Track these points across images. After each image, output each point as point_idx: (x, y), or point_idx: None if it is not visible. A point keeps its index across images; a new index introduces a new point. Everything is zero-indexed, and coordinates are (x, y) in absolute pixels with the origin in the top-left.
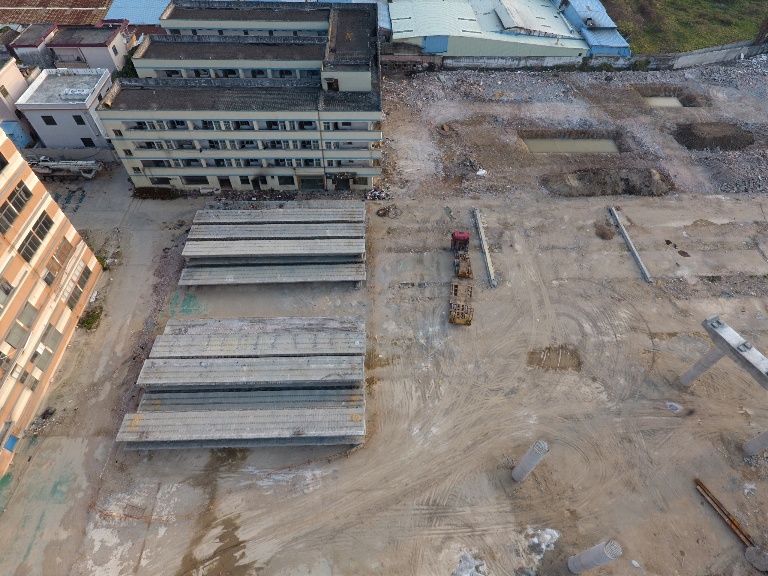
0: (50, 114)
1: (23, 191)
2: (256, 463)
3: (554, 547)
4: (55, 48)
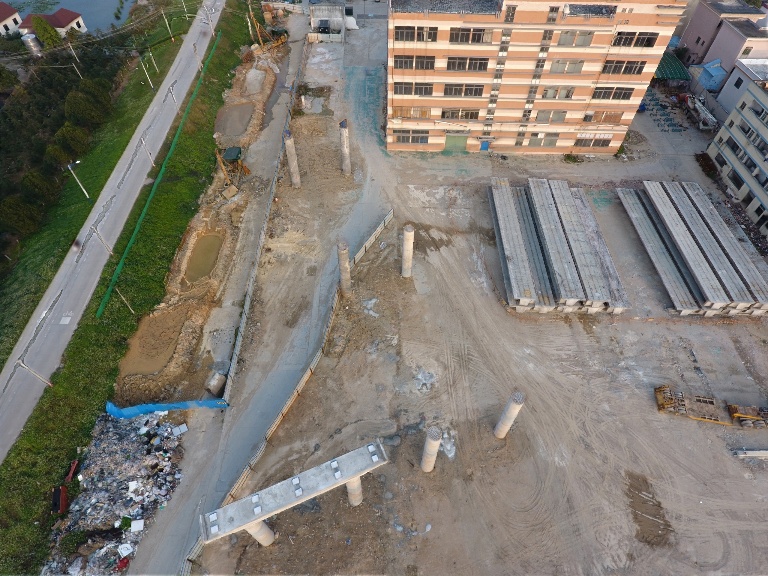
0: (744, 79)
1: (640, 68)
2: (487, 251)
3: (441, 450)
4: None
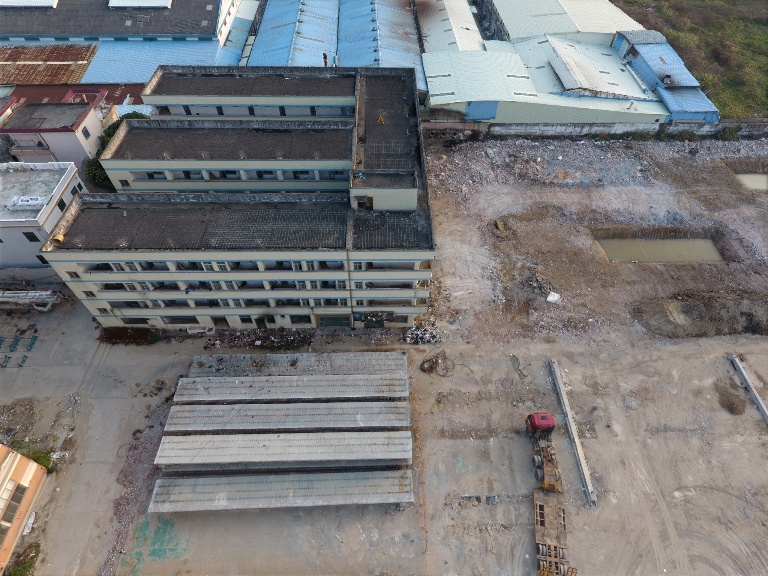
0: None
1: None
2: None
3: None
4: (9, 133)
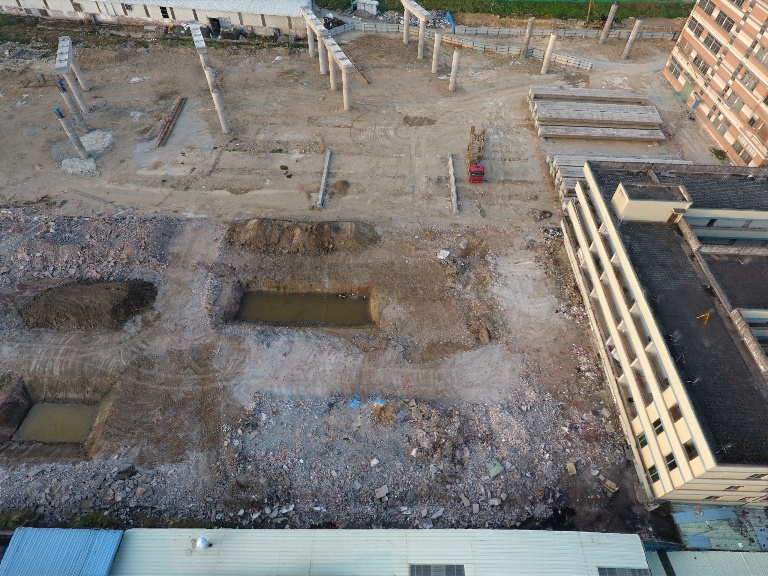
0: None
1: None
2: None
3: None
4: None
